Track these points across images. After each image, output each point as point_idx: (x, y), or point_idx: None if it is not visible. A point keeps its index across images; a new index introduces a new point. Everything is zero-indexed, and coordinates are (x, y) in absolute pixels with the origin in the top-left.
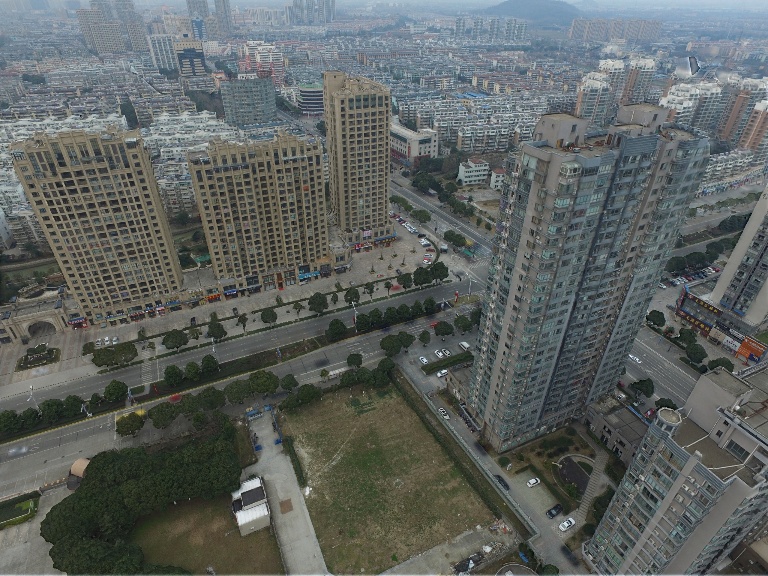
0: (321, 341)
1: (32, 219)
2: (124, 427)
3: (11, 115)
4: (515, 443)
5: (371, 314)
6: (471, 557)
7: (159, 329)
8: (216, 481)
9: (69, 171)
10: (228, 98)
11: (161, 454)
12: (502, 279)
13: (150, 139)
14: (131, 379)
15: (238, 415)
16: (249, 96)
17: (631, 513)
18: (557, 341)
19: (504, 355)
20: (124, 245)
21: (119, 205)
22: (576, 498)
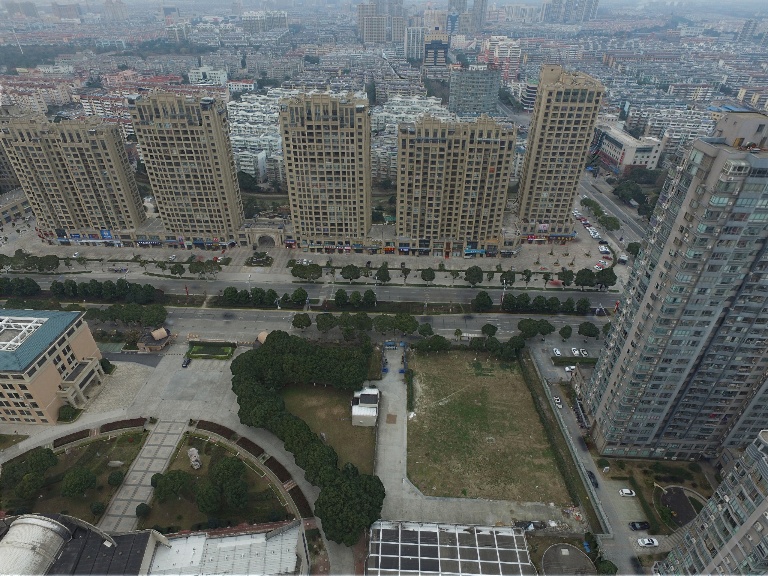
0: (466, 308)
1: (282, 163)
2: (298, 321)
3: (289, 86)
4: (622, 452)
5: (519, 297)
6: (533, 522)
7: (342, 263)
8: (346, 376)
9: (312, 124)
10: (455, 86)
11: (315, 346)
12: (644, 275)
13: (381, 115)
14: (312, 293)
15: (378, 342)
16: (474, 86)
17: (707, 535)
18: (691, 354)
19: (628, 353)
20: (335, 190)
21: (339, 157)
22: (670, 525)
